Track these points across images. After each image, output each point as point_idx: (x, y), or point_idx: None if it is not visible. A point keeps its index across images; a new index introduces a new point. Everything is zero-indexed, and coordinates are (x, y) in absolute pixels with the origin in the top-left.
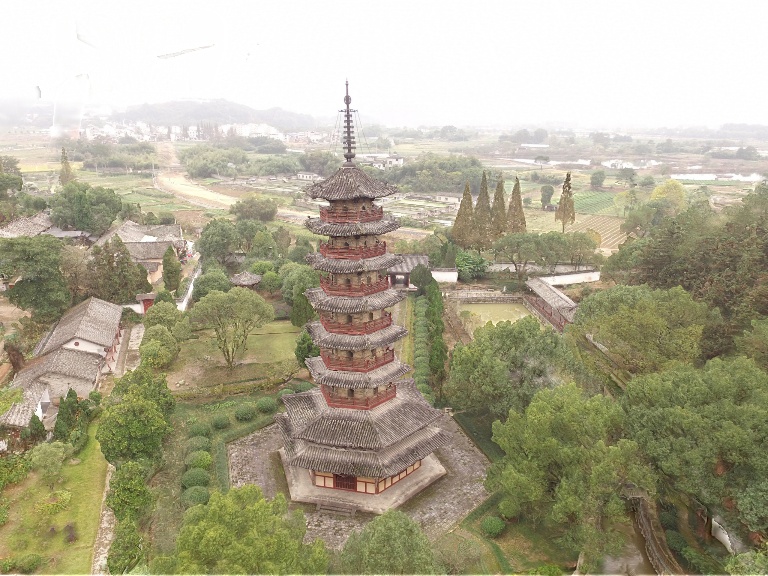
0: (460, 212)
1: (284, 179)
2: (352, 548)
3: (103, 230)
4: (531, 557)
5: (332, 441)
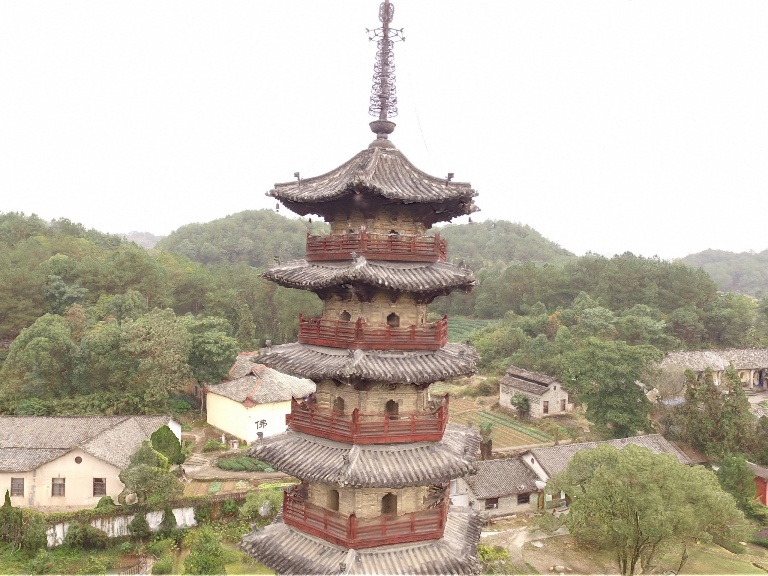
0: None
1: None
2: None
3: None
4: None
5: None
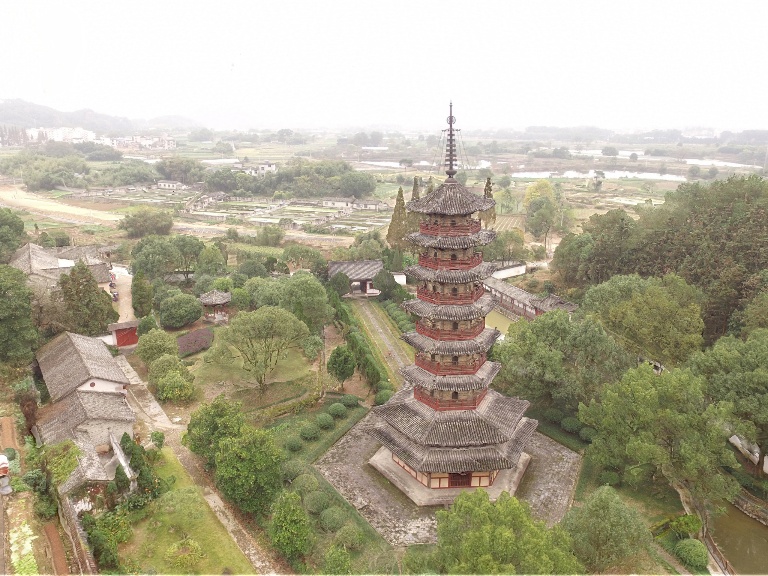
0: (395, 217)
1: (144, 189)
2: (578, 528)
3: (9, 256)
4: (650, 513)
5: (457, 442)
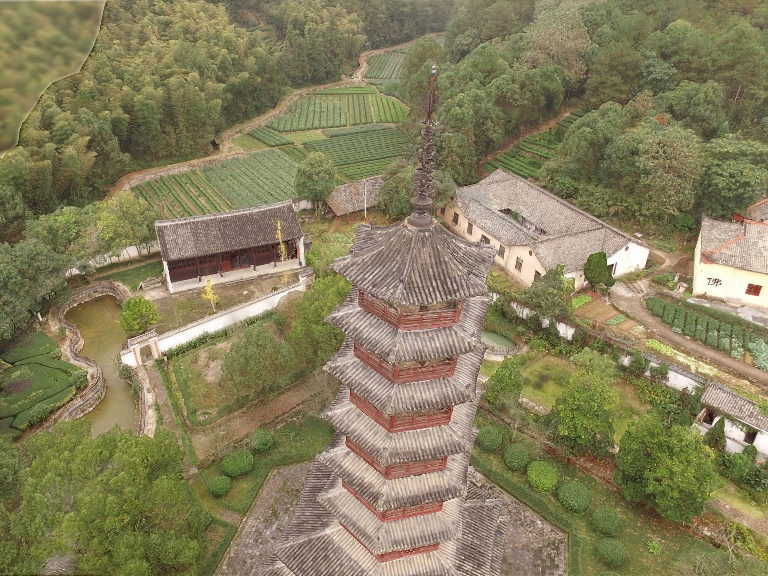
0: None
1: None
2: None
3: None
4: None
5: None
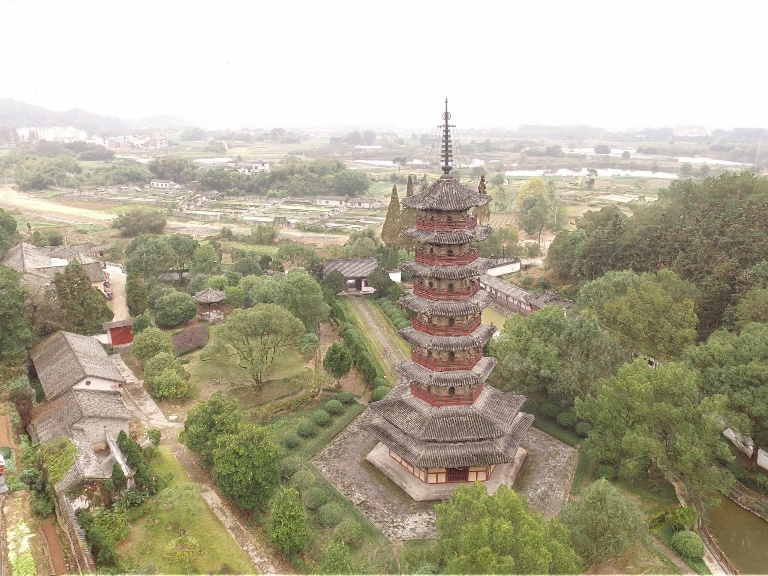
0: (389, 215)
1: (136, 188)
2: (576, 520)
3: (2, 255)
4: (646, 506)
5: (454, 437)
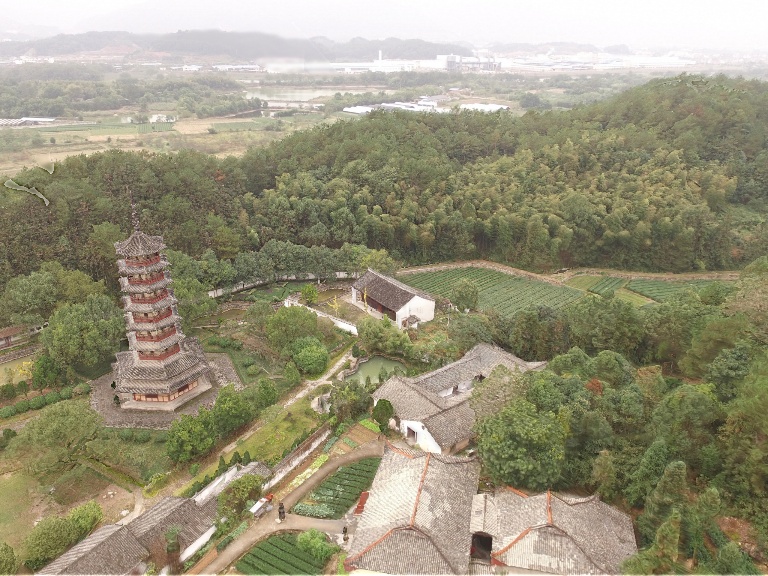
0: None
1: None
2: None
3: None
4: None
5: None
